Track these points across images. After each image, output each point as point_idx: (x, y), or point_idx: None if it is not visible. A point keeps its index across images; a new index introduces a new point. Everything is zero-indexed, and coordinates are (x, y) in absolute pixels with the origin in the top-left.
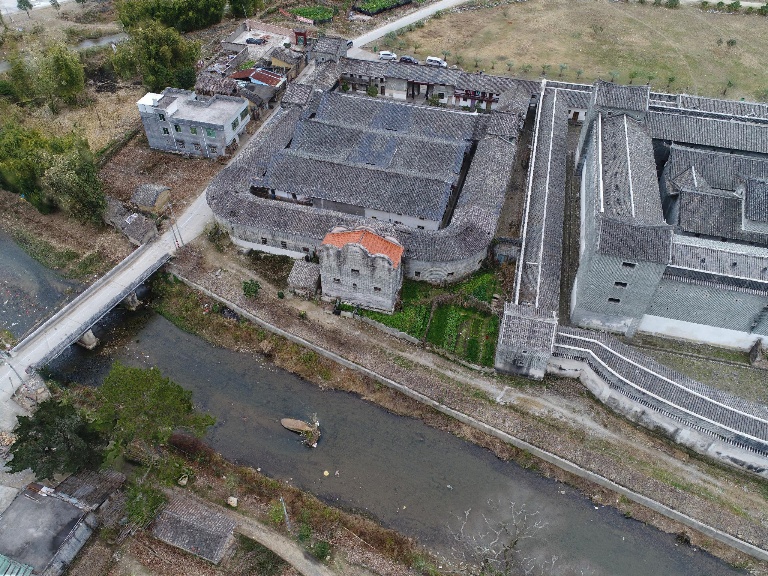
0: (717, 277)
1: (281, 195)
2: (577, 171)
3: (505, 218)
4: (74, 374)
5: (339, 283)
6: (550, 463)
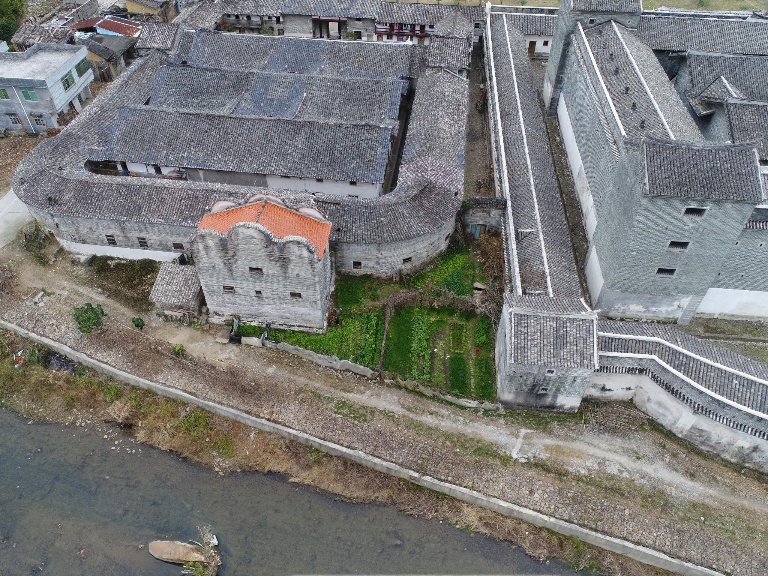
0: None
1: (137, 170)
2: (550, 109)
3: (469, 176)
4: None
5: (233, 293)
6: (617, 554)
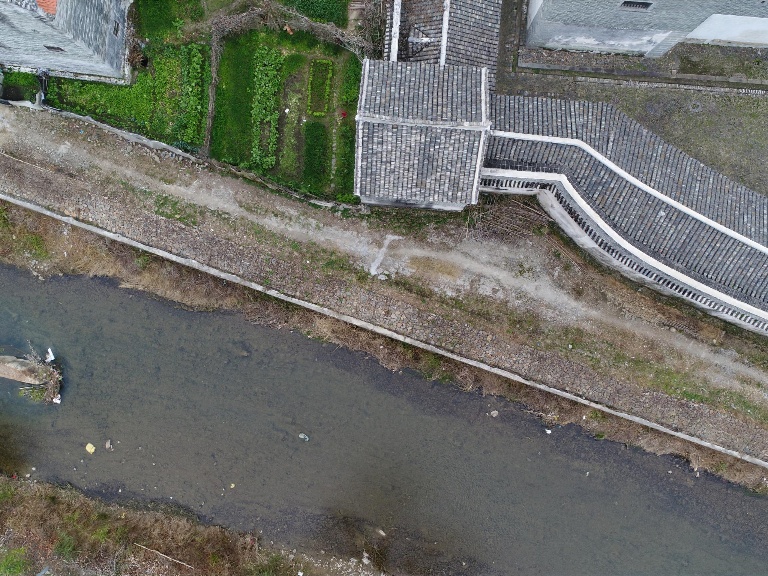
0: None
1: None
2: None
3: None
4: None
5: None
6: (474, 366)
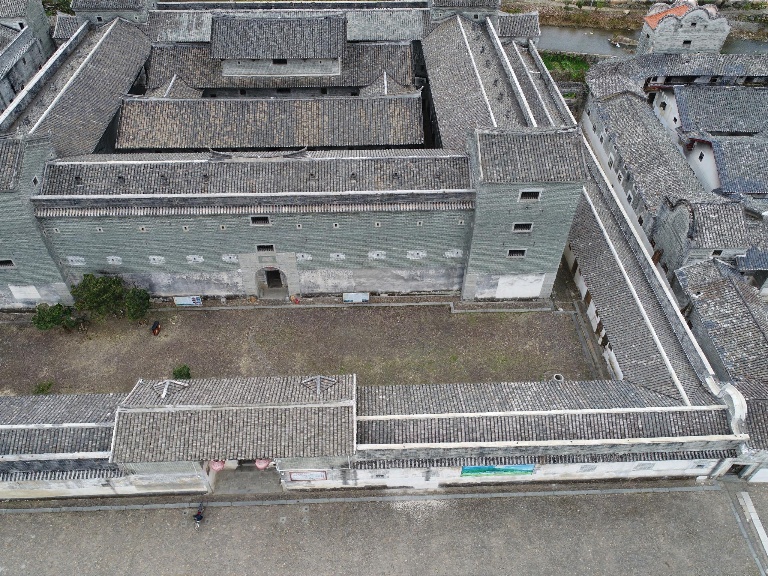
0: (381, 5)
1: None
2: None
3: None
4: None
5: None
6: None
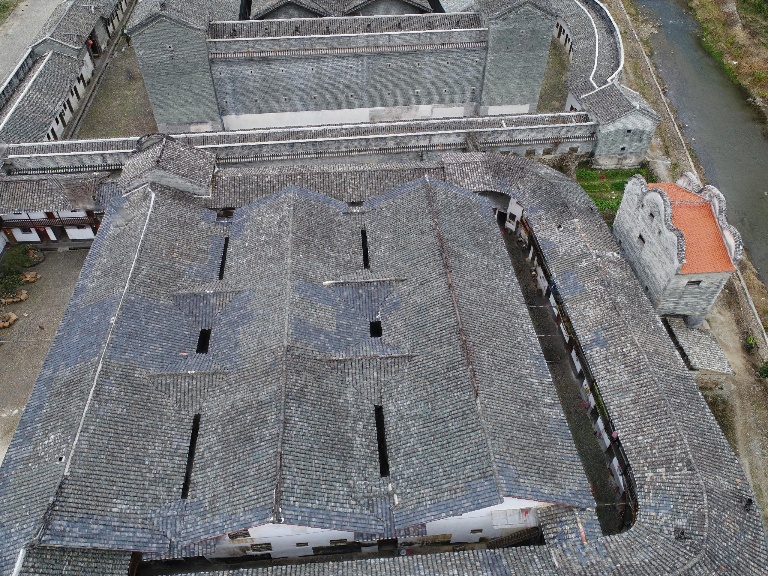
0: None
1: None
2: None
3: None
4: None
5: None
6: None
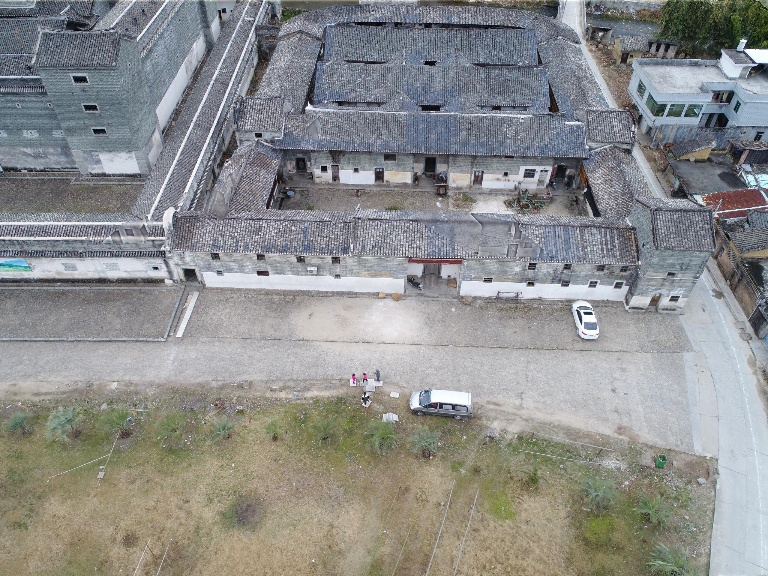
0: None
1: None
2: None
3: None
4: (550, 11)
5: None
6: None
